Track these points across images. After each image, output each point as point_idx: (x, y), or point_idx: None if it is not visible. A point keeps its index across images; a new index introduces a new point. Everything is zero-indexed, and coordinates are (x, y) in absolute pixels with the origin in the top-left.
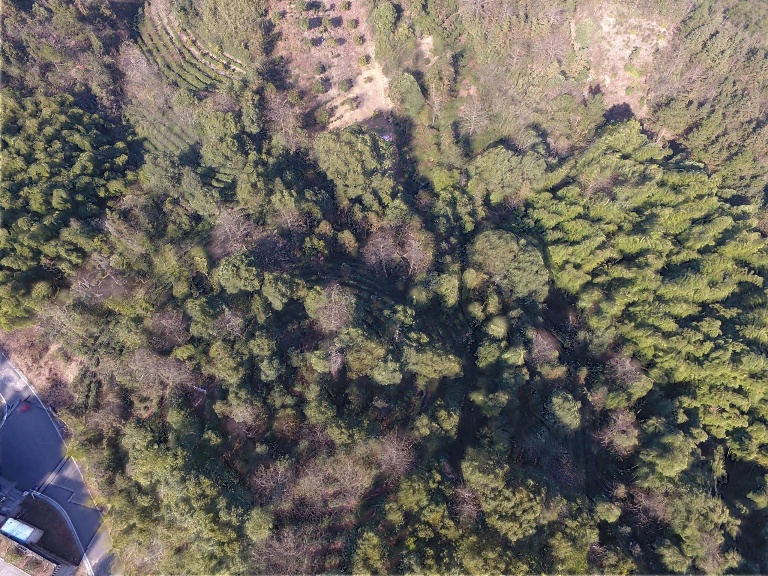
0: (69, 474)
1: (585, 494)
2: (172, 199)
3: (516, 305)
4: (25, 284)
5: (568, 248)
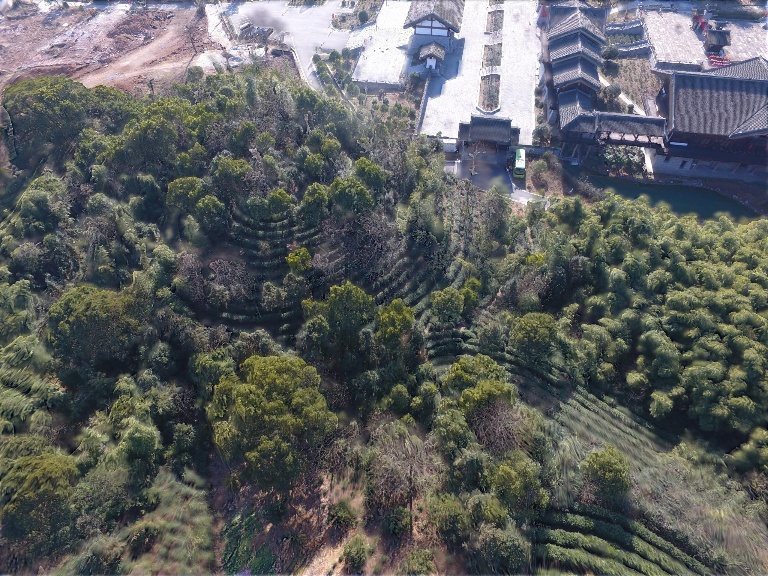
0: (447, 171)
1: (108, 164)
2: (507, 322)
3: (104, 287)
4: (571, 222)
5: (7, 358)
